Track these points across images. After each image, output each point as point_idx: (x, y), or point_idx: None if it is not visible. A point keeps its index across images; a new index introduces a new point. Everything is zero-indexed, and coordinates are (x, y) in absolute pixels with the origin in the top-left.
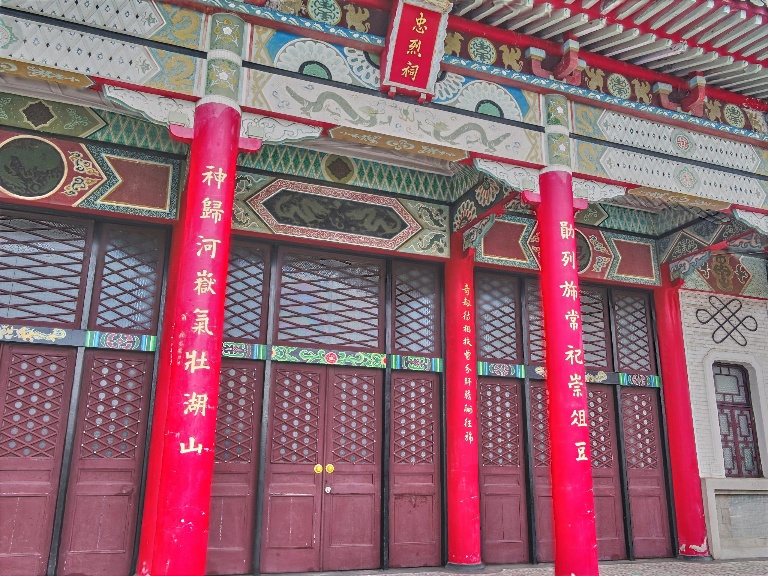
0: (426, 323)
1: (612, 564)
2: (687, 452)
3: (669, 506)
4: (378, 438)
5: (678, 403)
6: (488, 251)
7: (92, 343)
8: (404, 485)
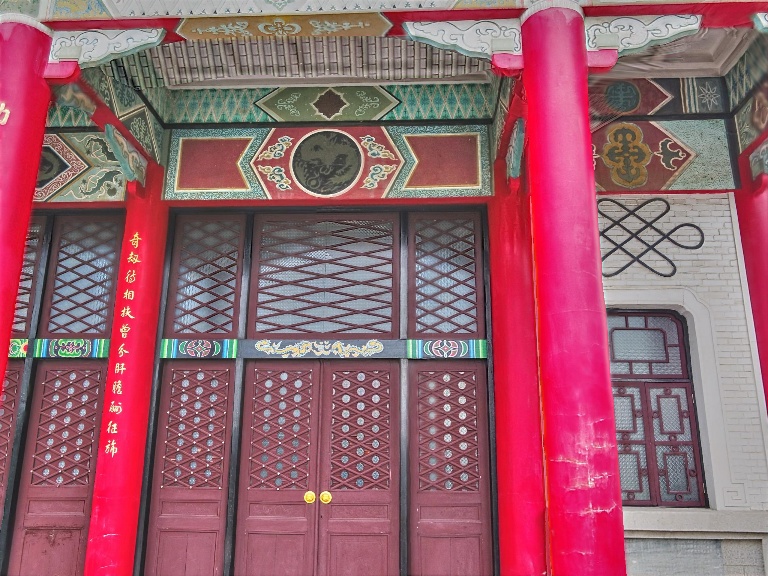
0: (98, 293)
1: None
2: (515, 464)
3: (492, 554)
4: (11, 451)
5: (507, 382)
6: (185, 183)
7: None
8: (41, 515)
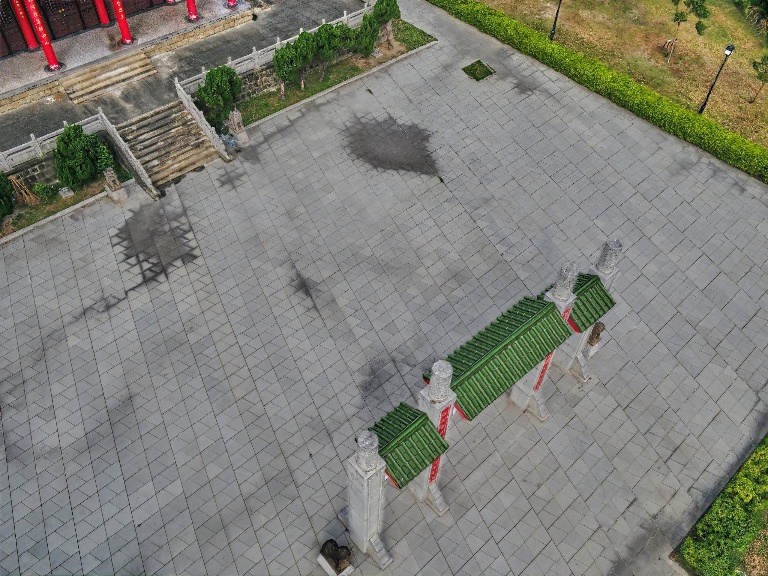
0: None
1: (146, 12)
2: None
3: None
4: None
5: None
6: None
7: None
8: (84, 8)
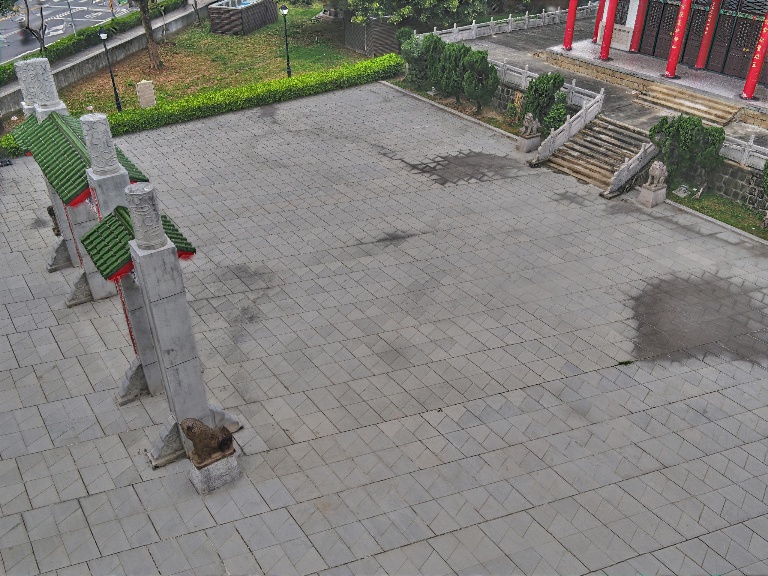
0: None
1: None
2: None
3: None
4: None
5: None
6: None
7: (695, 8)
8: None
